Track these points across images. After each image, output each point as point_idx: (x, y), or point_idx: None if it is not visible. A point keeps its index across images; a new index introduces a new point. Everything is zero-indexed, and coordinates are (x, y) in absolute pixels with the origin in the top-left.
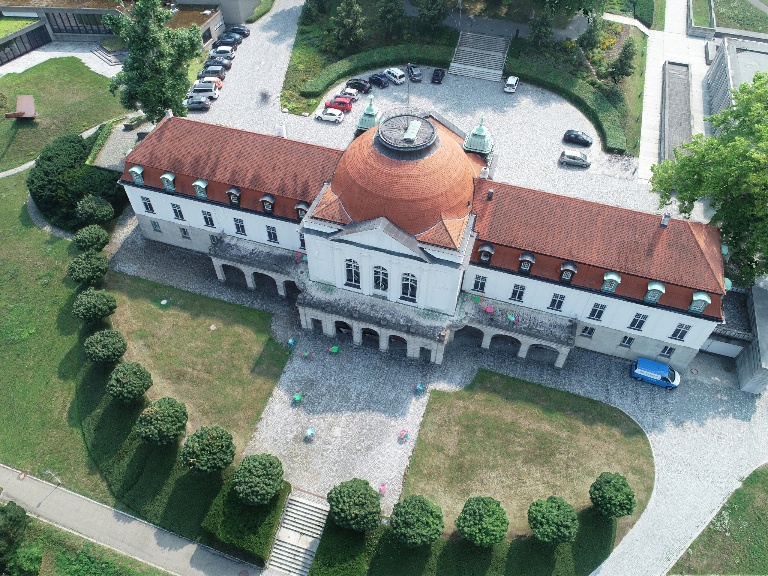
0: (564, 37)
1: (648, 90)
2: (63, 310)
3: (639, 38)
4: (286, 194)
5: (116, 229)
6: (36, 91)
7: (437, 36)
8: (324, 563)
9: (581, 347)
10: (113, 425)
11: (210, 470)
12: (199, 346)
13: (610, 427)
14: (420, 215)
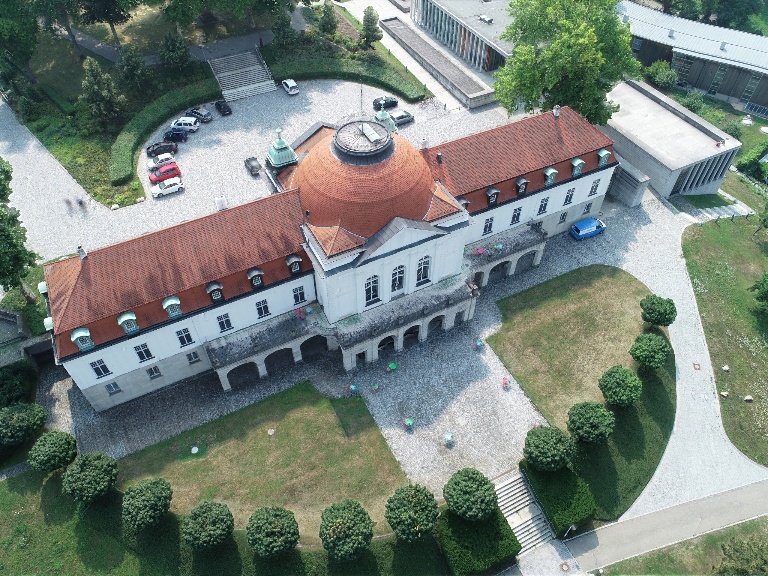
0: (297, 31)
1: (389, 47)
2: (82, 548)
3: (343, 12)
4: (271, 257)
5: (49, 429)
6: None
7: (190, 74)
8: (563, 509)
9: None
10: None
11: (433, 524)
12: (278, 456)
13: (601, 279)
14: (420, 199)
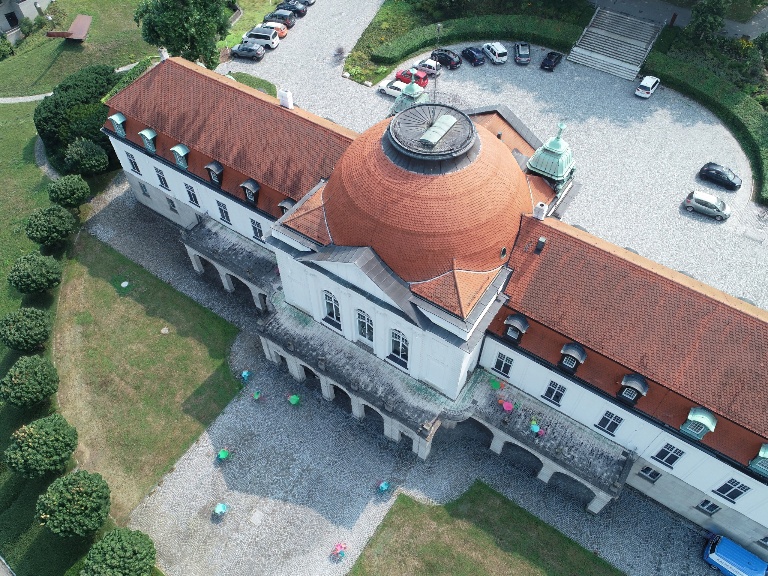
0: (740, 33)
1: None
2: None
3: None
4: (272, 184)
5: (111, 183)
6: (98, 12)
7: (565, 10)
8: None
9: (637, 488)
10: (8, 427)
11: (64, 534)
12: (140, 351)
13: None
14: (421, 256)
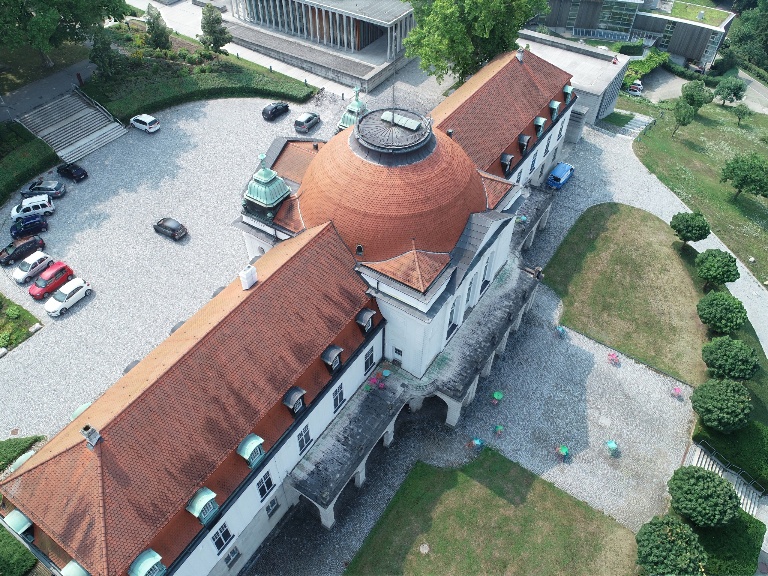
0: None
1: (232, 51)
2: None
3: None
4: (342, 324)
5: None
6: None
7: None
8: (765, 461)
9: None
10: None
11: None
12: (455, 575)
13: (606, 218)
14: (479, 185)
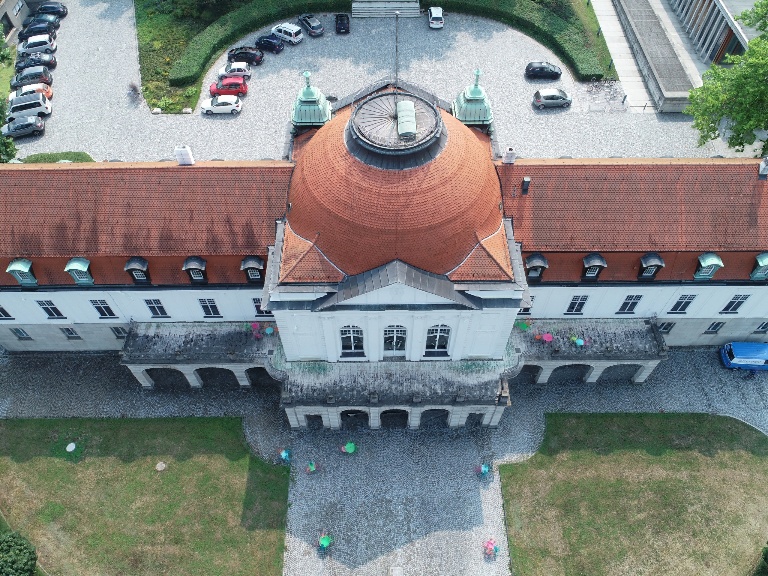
0: None
1: None
2: None
3: None
4: (222, 251)
5: None
6: None
7: None
8: None
9: None
10: None
11: None
12: (149, 504)
13: (731, 446)
14: (449, 244)
